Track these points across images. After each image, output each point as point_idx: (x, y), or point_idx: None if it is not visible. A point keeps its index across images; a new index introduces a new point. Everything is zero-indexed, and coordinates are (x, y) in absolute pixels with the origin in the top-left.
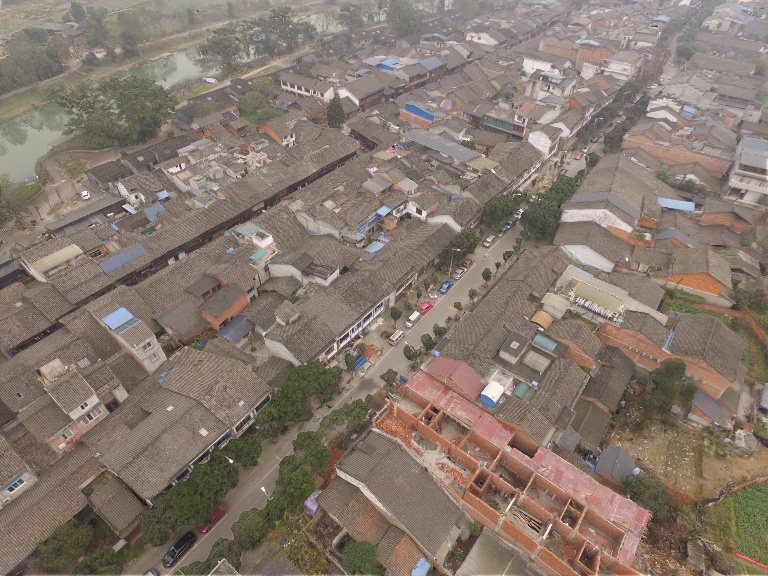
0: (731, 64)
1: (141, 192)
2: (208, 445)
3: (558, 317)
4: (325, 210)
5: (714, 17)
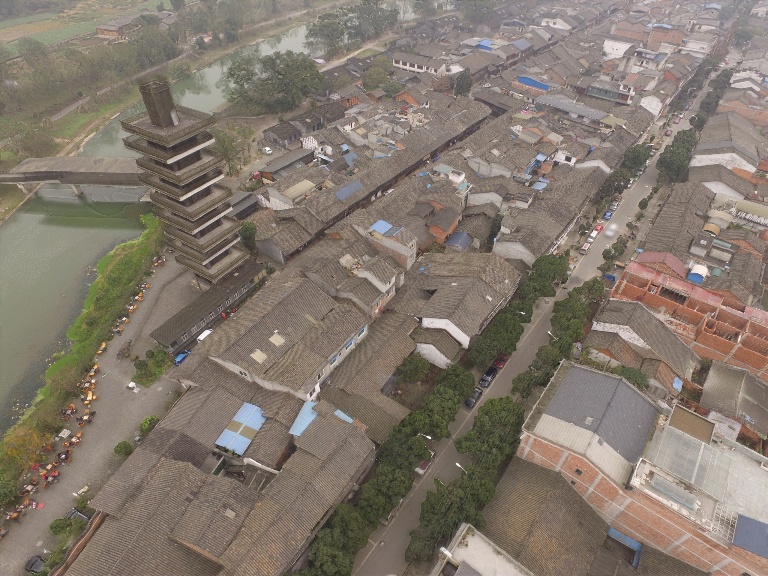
0: None
1: (329, 144)
2: (495, 307)
3: (723, 227)
4: (493, 157)
5: (762, 5)
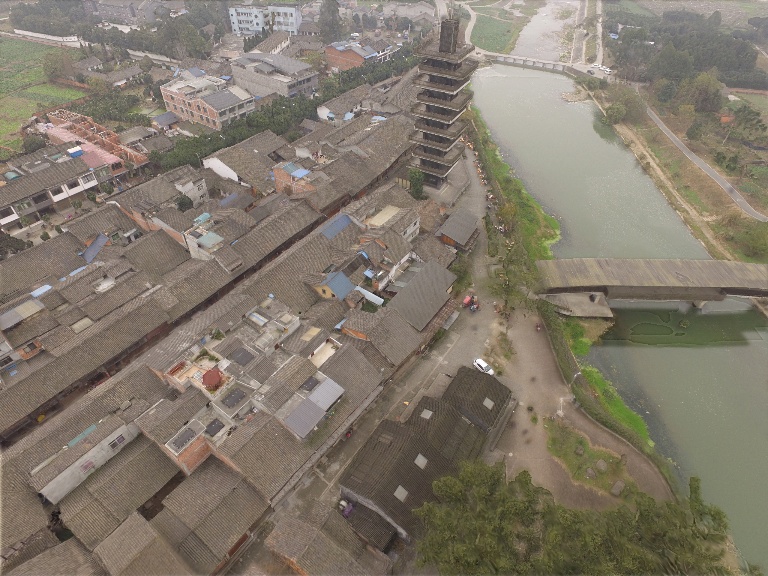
0: None
1: (366, 312)
2: None
3: None
4: None
5: None
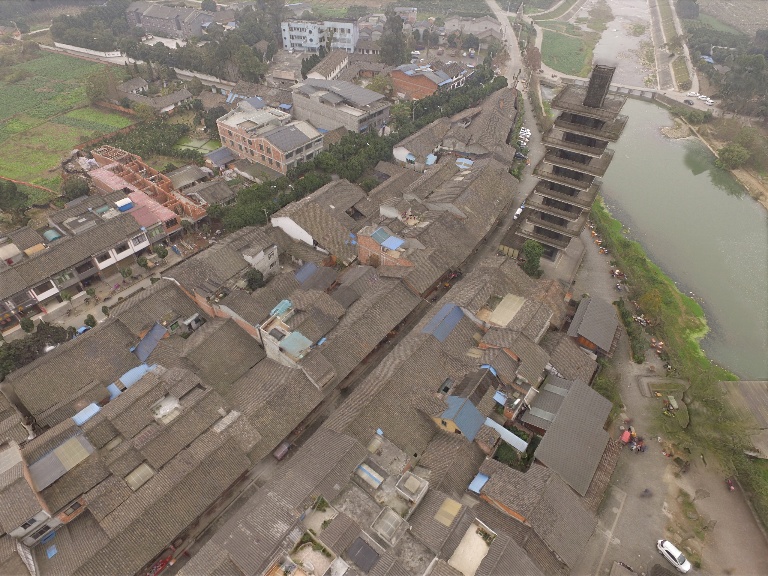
0: None
1: (511, 468)
2: None
3: None
4: None
5: None
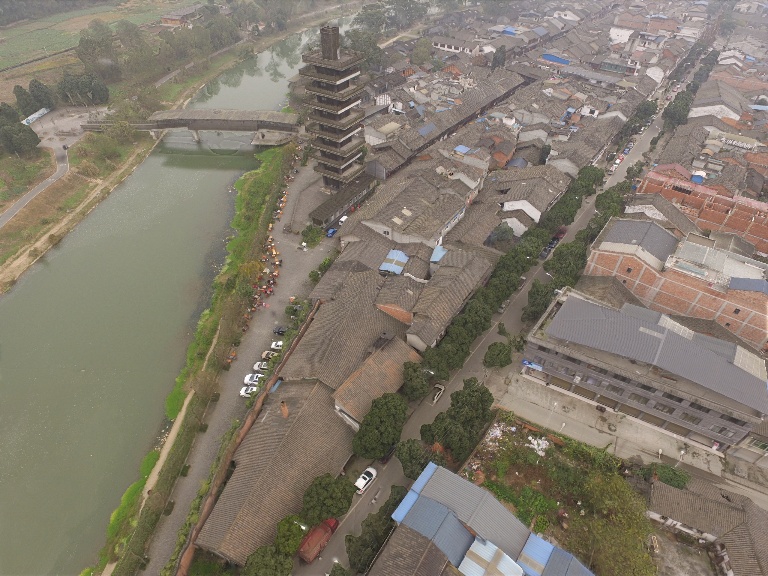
0: (767, 34)
1: (400, 101)
2: (555, 196)
3: (716, 152)
4: None
5: (744, 2)
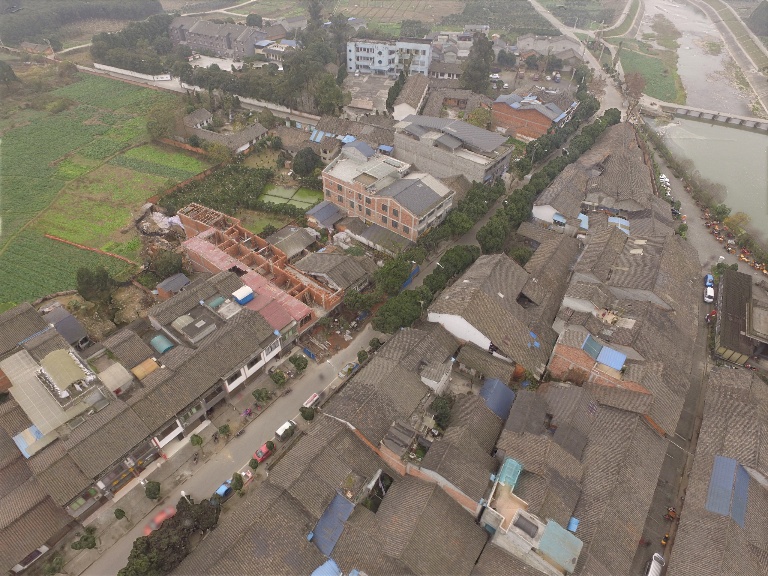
0: None
1: None
2: None
3: None
4: None
5: None
